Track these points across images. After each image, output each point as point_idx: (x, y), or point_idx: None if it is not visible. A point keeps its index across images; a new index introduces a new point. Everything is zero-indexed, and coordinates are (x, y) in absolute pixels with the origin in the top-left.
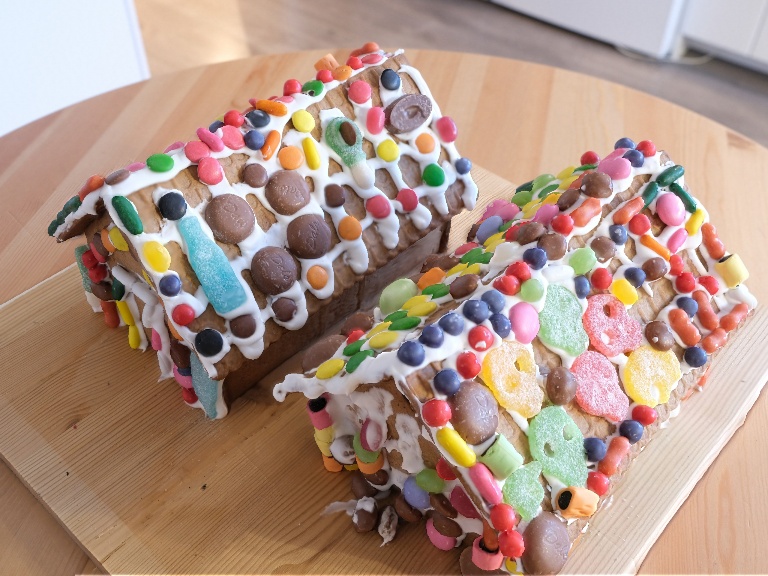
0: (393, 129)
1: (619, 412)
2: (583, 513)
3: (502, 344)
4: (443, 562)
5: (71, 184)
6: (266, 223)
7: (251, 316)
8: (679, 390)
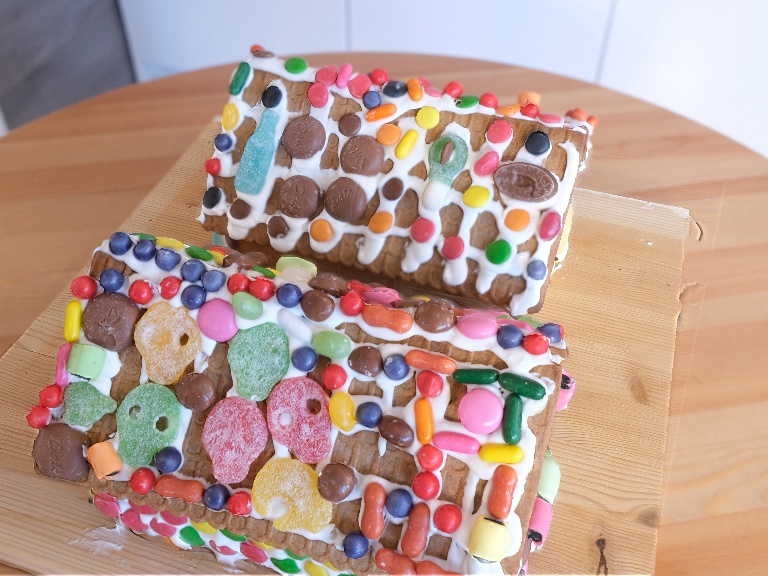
0: None
1: (220, 470)
2: None
3: (181, 309)
4: None
5: None
6: (329, 164)
7: (251, 208)
8: (316, 548)
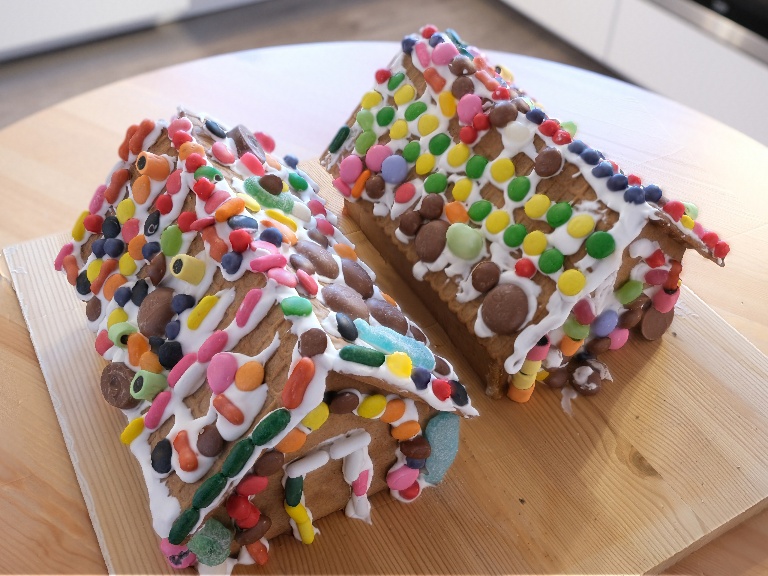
0: None
1: None
2: None
3: None
4: (631, 350)
5: None
6: None
7: None
8: None
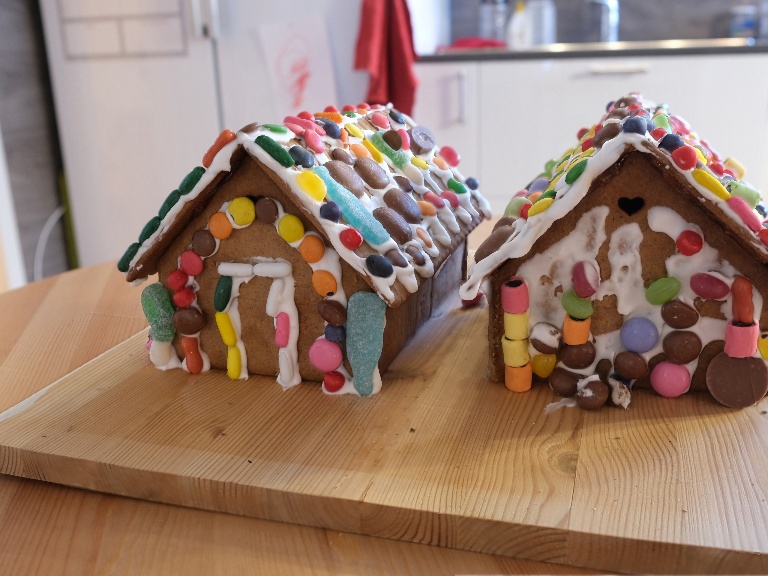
0: (416, 148)
1: None
2: None
3: None
4: (687, 403)
5: (33, 335)
6: None
7: None
8: None
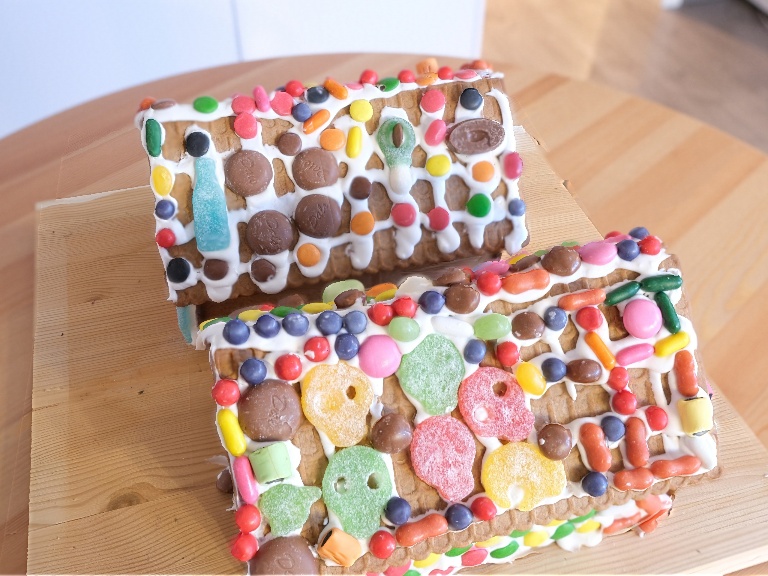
0: (452, 146)
1: (451, 491)
2: (338, 560)
3: (339, 364)
4: None
5: None
6: (283, 189)
7: (227, 263)
8: (559, 509)
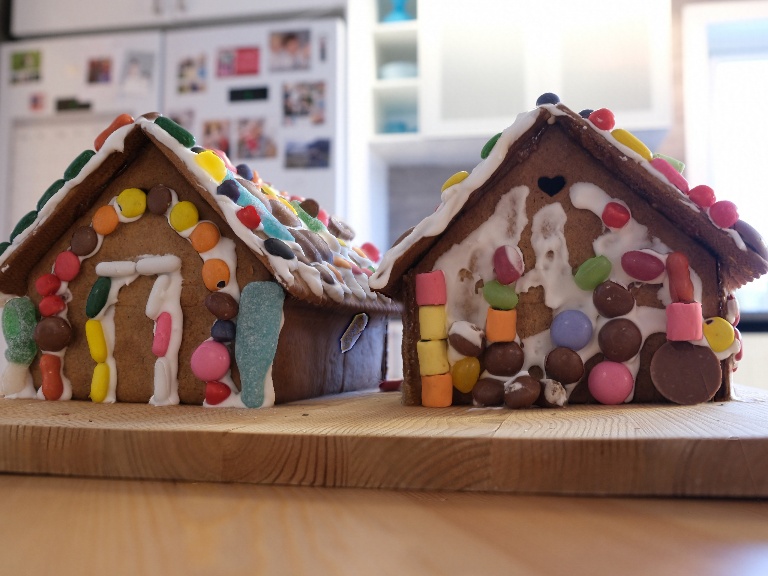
0: (335, 231)
1: None
2: None
3: None
4: (632, 405)
5: None
6: None
7: None
8: None
